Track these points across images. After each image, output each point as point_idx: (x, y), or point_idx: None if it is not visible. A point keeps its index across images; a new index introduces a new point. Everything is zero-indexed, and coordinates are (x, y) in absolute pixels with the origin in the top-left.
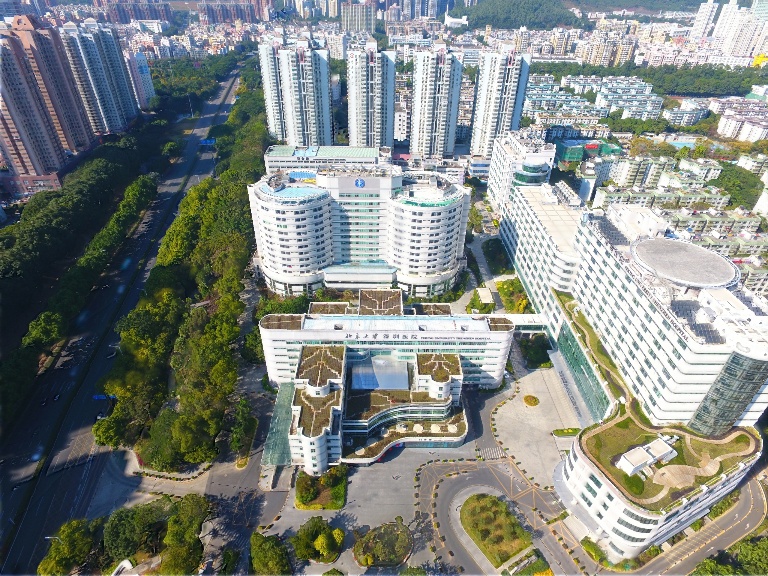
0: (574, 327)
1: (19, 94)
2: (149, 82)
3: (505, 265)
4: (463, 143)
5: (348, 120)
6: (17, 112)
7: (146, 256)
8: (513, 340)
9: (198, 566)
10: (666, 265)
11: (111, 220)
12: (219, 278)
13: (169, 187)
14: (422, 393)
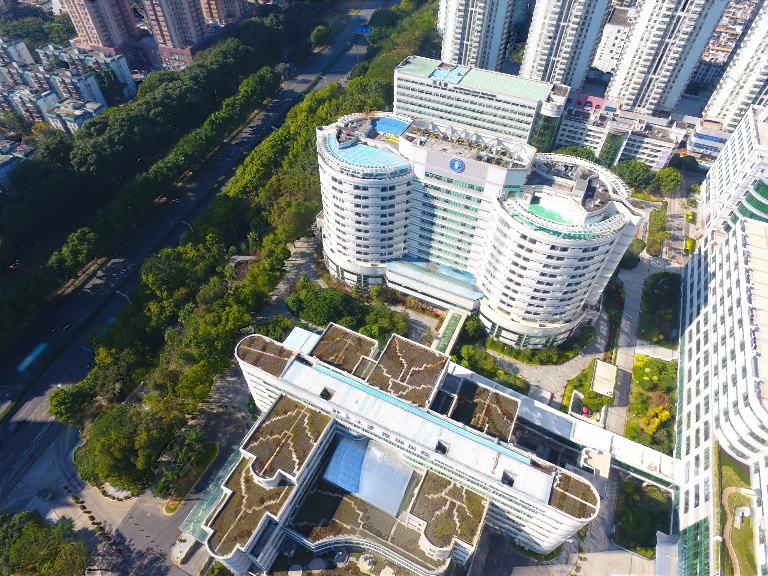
0: (718, 554)
1: None
2: None
3: (666, 331)
4: (699, 93)
5: (529, 32)
6: None
7: (229, 172)
8: (603, 495)
9: None
10: None
11: (205, 121)
12: (275, 230)
13: (298, 84)
14: (411, 532)
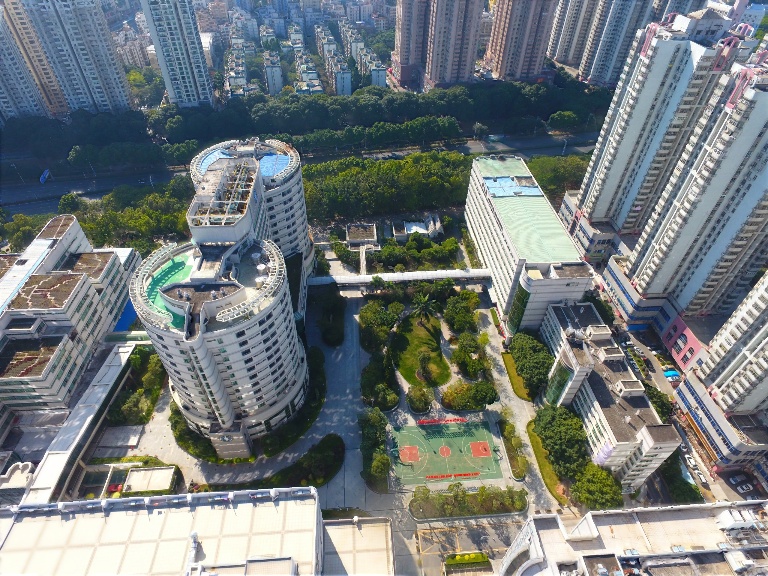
0: None
1: (452, 1)
2: None
3: None
4: None
5: None
6: (442, 17)
7: None
8: None
9: None
10: None
11: (345, 128)
12: None
13: None
14: None
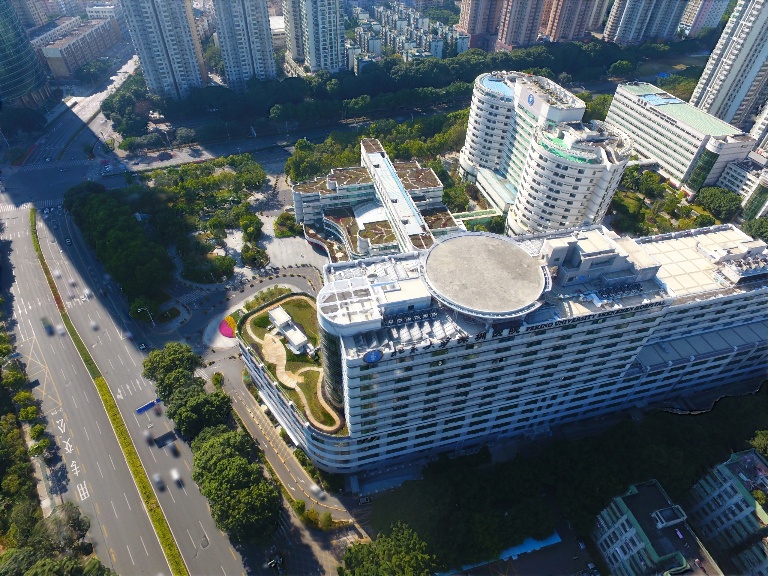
0: None
1: None
2: (719, 10)
3: None
4: None
5: None
6: None
7: None
8: None
9: (226, 186)
10: (459, 253)
11: None
12: None
13: None
14: None
